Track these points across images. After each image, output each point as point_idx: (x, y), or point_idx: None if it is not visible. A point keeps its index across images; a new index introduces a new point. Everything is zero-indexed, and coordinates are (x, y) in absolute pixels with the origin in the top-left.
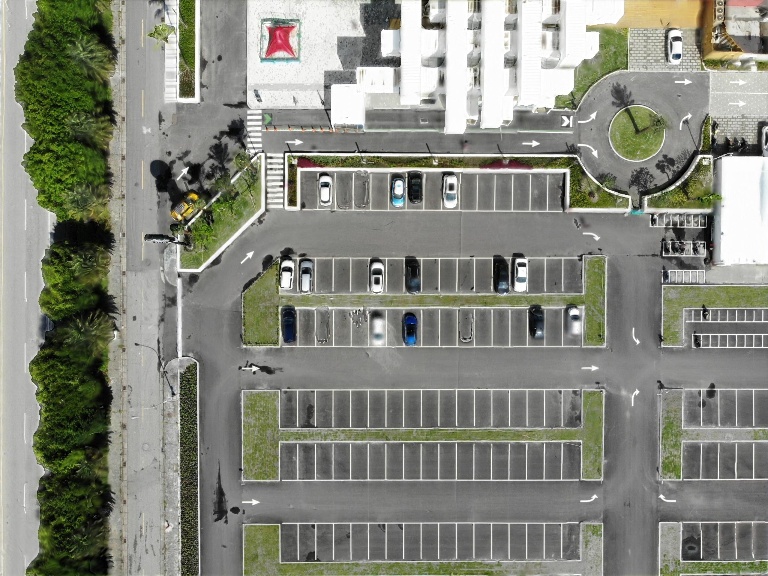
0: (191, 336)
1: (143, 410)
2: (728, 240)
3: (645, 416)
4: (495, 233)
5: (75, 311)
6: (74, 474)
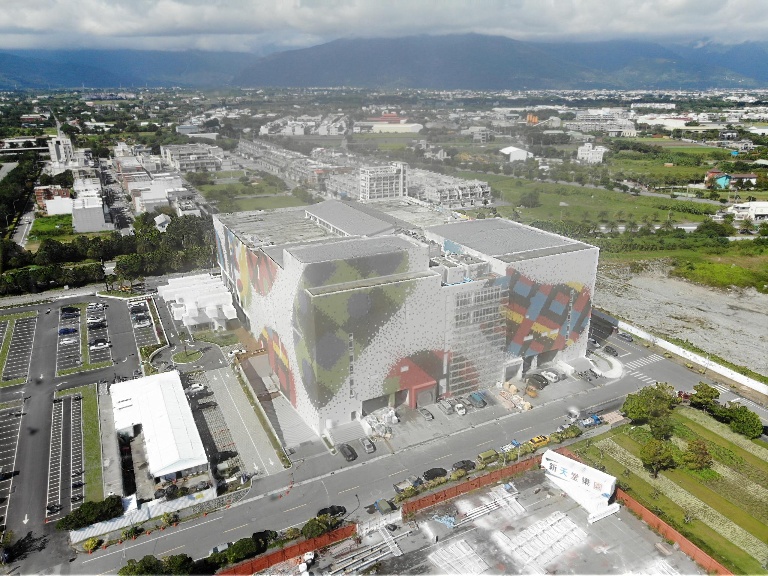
0: (66, 299)
1: (31, 298)
2: (126, 383)
3: (6, 398)
4: (123, 339)
5: (76, 272)
6: (4, 280)
